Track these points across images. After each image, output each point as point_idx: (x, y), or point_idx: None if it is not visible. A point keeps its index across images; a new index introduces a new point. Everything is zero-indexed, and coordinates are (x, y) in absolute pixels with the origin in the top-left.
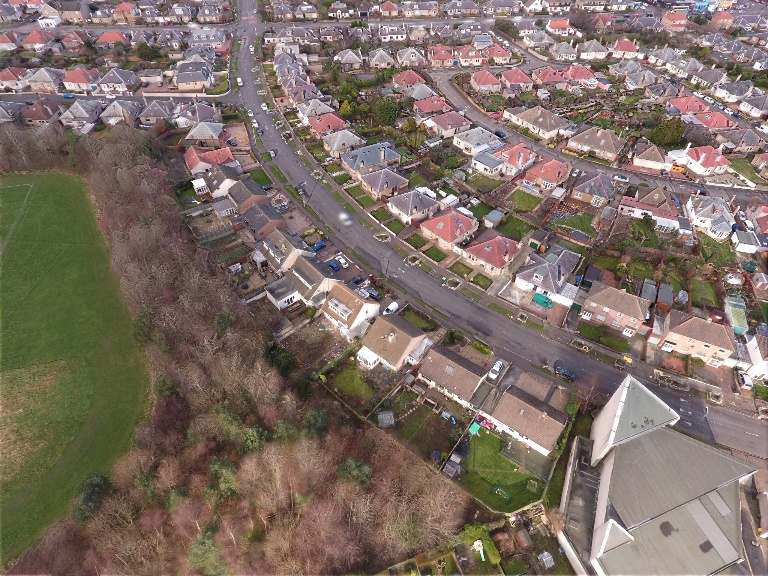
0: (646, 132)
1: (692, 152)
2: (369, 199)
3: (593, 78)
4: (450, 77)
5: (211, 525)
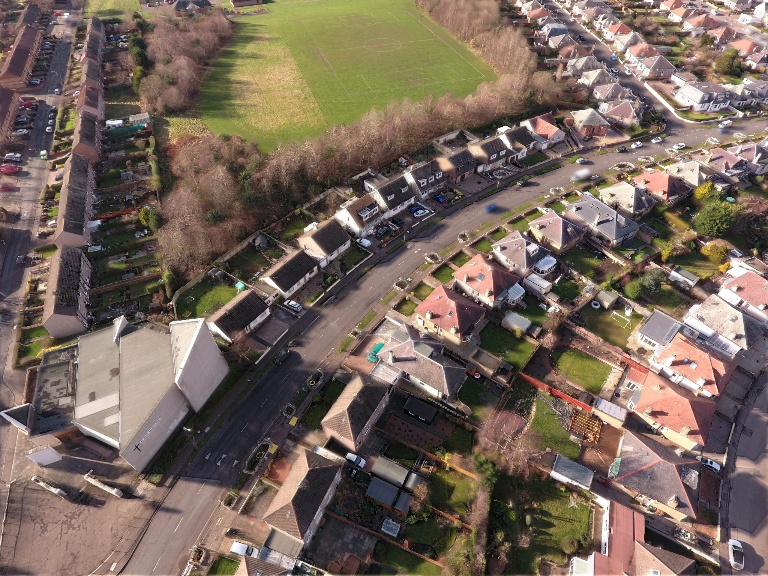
0: None
1: None
2: (527, 227)
3: None
4: None
5: (199, 170)
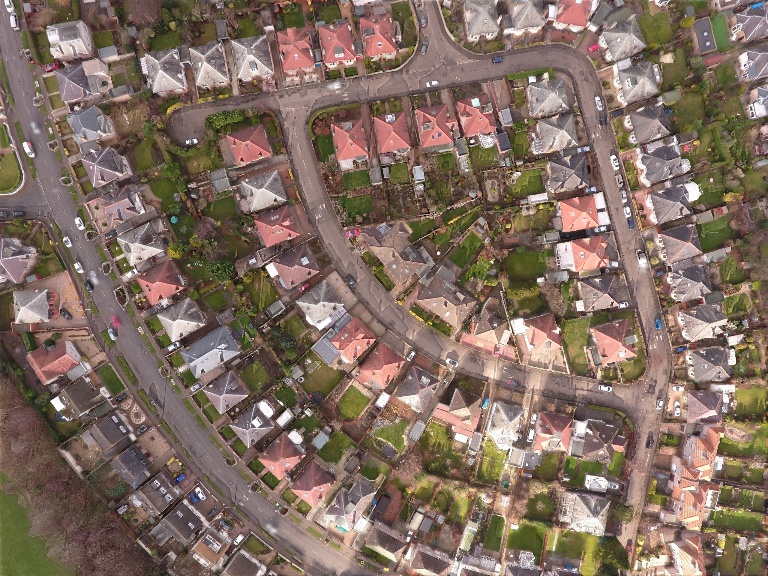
0: (504, 282)
1: (530, 332)
2: None
3: (490, 136)
4: (308, 112)
5: None
